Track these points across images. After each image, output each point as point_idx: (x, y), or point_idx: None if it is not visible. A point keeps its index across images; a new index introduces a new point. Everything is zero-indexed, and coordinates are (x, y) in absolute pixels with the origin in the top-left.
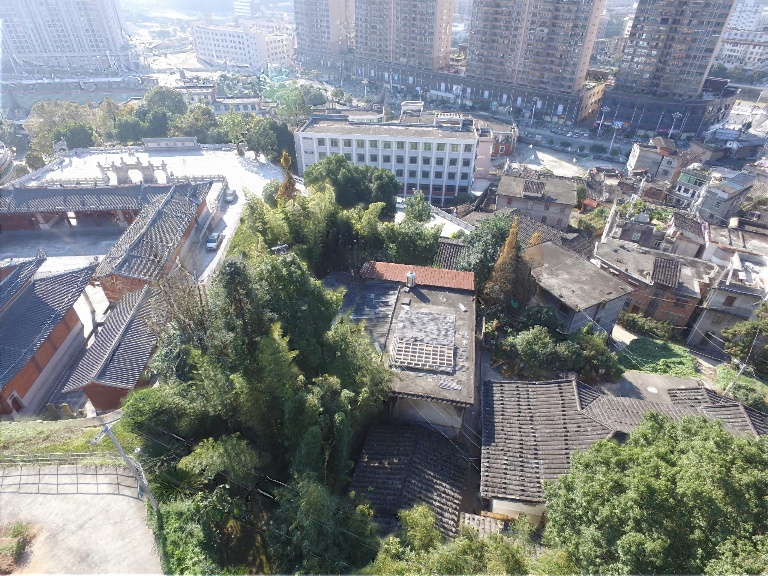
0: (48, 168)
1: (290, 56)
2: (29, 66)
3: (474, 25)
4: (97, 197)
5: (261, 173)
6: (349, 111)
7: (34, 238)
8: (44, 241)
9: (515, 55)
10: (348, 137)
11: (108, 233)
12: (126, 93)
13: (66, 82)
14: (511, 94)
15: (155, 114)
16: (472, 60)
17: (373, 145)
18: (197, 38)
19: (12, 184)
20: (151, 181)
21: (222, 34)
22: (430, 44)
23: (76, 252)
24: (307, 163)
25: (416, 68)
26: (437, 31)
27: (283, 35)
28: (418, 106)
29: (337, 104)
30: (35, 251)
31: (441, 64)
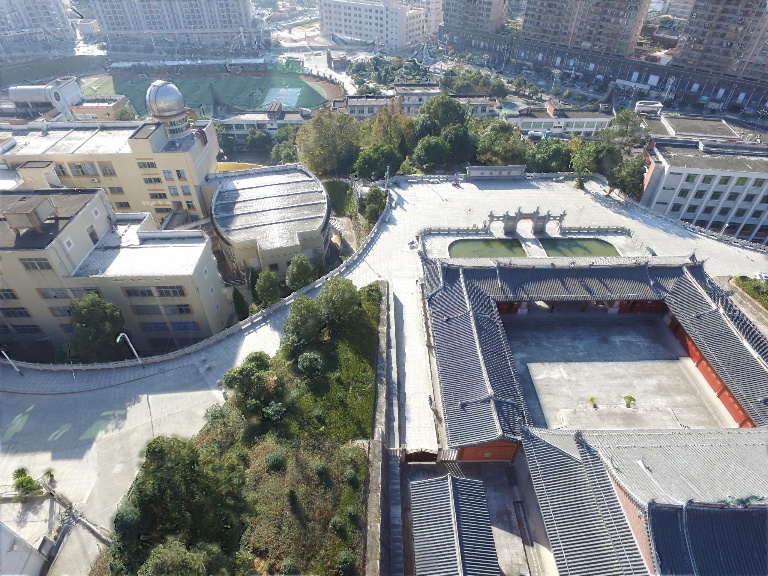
0: (387, 205)
1: (429, 33)
2: (169, 45)
3: (698, 8)
4: (599, 281)
5: (639, 218)
6: (572, 111)
7: (522, 328)
8: (540, 334)
9: (749, 45)
10: (730, 174)
11: (602, 323)
12: (276, 77)
13: (211, 64)
14: (732, 89)
15: (457, 133)
16: (685, 48)
17: (756, 184)
18: (325, 12)
19: (498, 262)
20: (540, 232)
21: (357, 8)
22: (628, 27)
23: (601, 355)
24: (659, 200)
25: (602, 54)
26: (640, 13)
27: (420, 9)
28: (654, 107)
29: (558, 103)
30: (548, 351)
31: (633, 50)
